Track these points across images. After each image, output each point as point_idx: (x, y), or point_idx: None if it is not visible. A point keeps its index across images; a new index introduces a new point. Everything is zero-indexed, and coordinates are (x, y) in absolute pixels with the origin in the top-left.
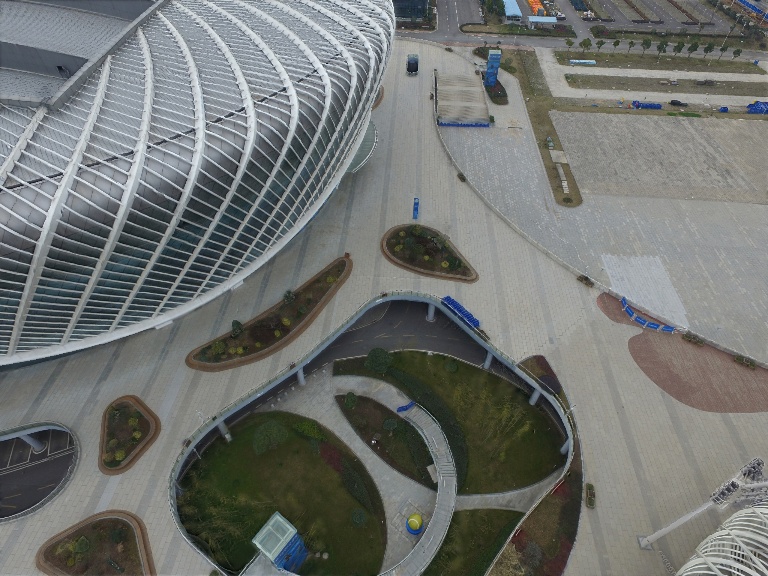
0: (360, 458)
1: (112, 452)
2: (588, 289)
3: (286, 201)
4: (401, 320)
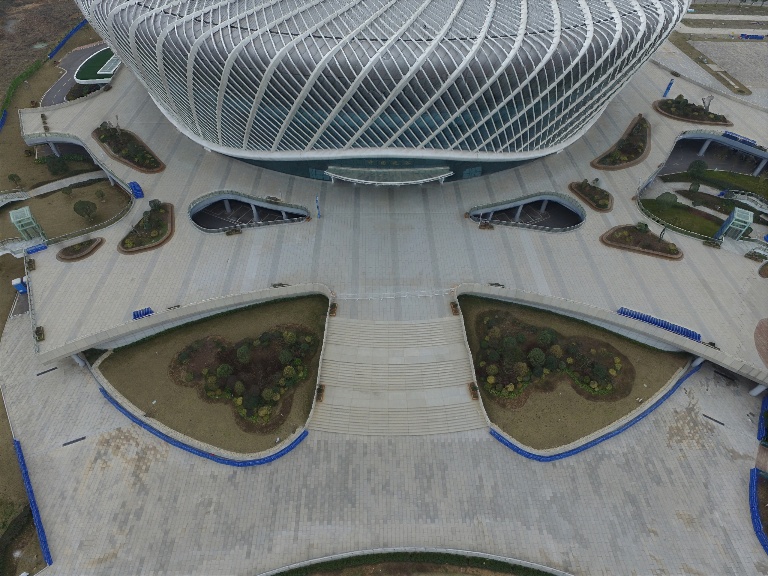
0: None
1: None
2: None
3: None
4: (682, 156)
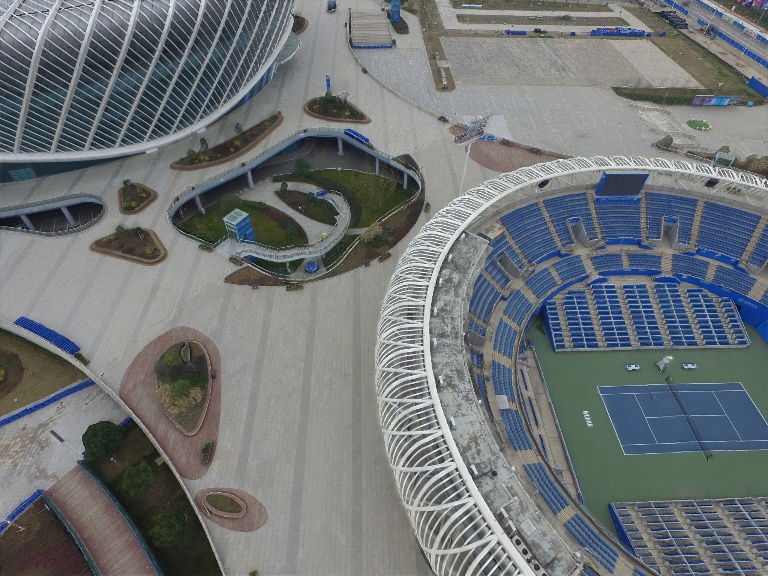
0: (292, 217)
1: (129, 202)
2: (444, 124)
3: (231, 60)
4: None
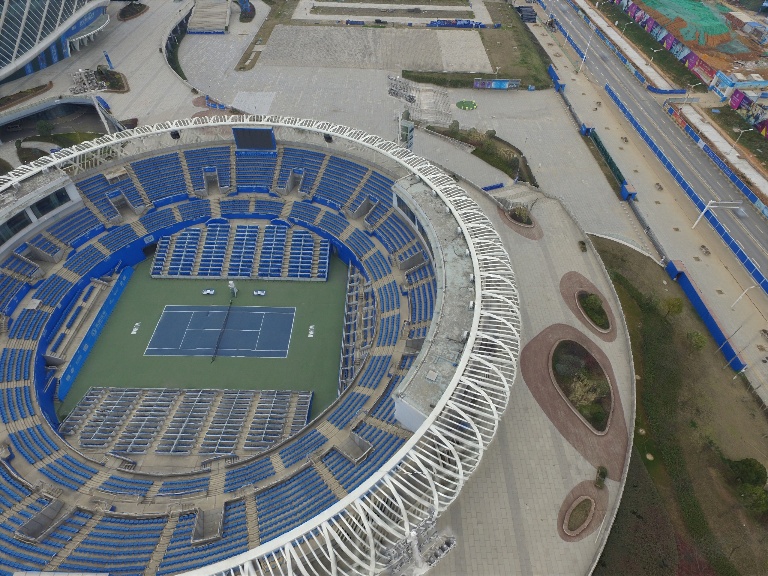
0: None
1: None
2: (194, 95)
3: None
4: (84, 121)
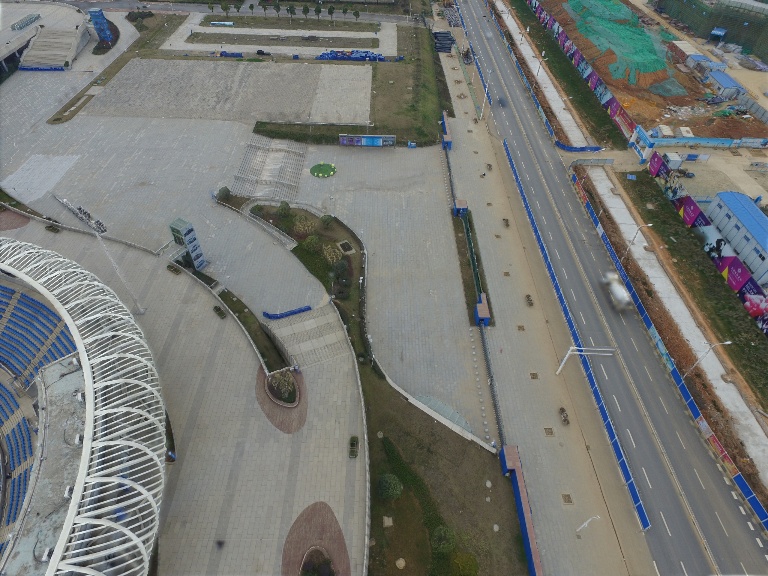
0: None
1: None
2: None
3: None
4: None
